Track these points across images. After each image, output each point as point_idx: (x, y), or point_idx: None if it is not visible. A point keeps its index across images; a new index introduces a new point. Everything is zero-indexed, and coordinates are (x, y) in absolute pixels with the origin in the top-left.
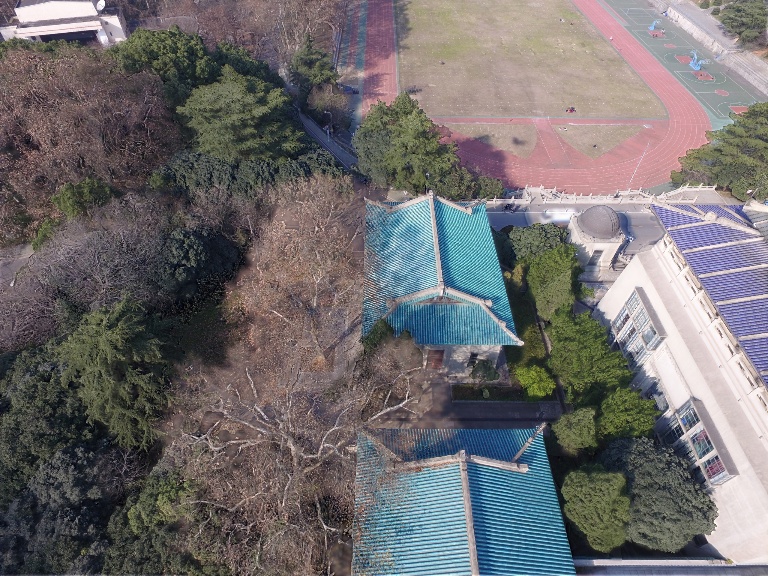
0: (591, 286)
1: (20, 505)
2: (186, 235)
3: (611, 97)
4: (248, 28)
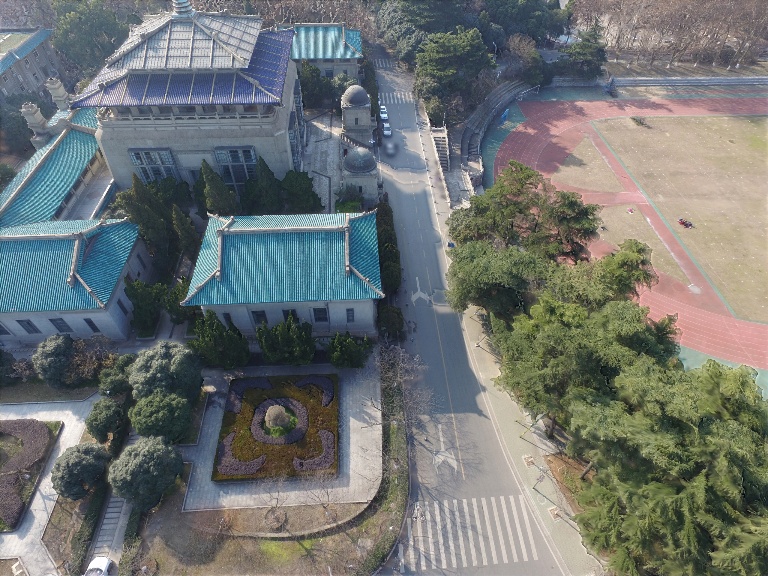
0: (327, 123)
1: (224, 3)
2: (329, 0)
3: (763, 269)
4: (597, 4)
